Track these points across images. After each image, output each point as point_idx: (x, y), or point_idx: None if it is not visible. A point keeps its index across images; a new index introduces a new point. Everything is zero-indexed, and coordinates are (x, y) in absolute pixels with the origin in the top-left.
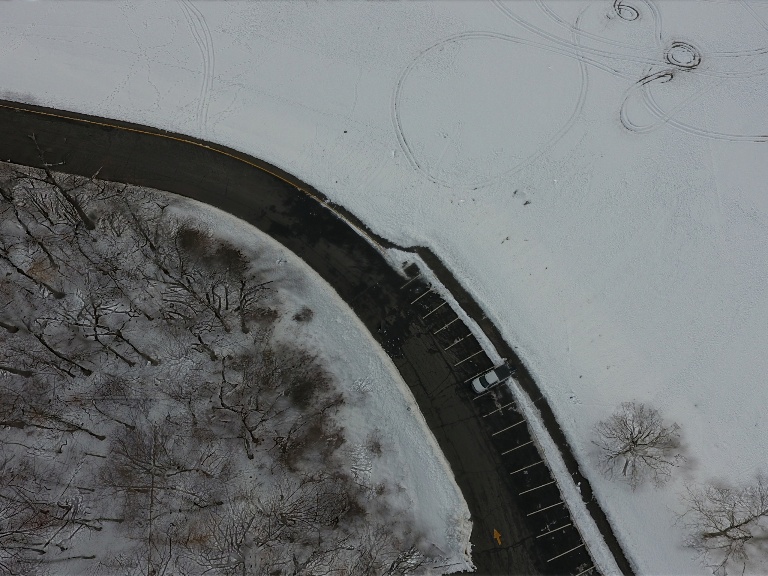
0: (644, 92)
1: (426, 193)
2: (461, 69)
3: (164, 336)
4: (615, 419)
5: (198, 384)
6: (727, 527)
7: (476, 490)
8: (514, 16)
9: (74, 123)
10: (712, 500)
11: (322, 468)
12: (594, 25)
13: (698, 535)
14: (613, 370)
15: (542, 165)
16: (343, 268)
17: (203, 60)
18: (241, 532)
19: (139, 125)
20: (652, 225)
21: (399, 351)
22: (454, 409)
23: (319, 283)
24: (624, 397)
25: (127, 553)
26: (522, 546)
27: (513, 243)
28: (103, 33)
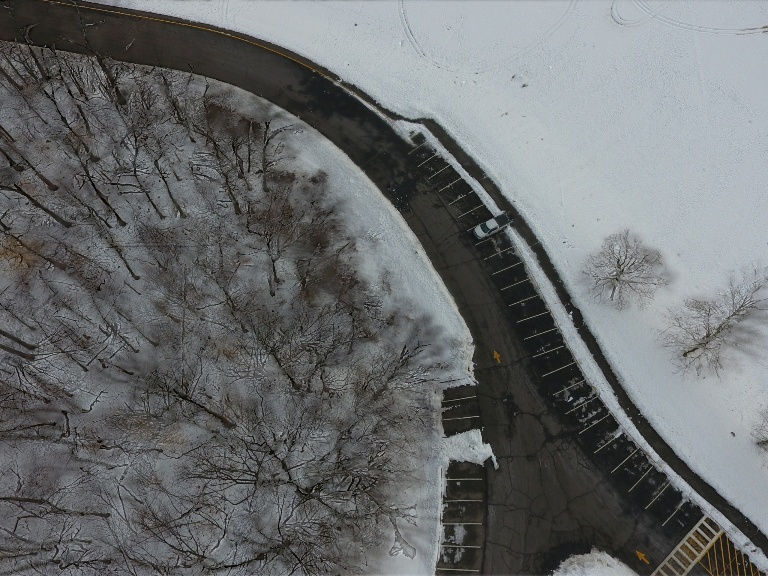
0: None
1: (431, 75)
2: None
3: (192, 193)
4: (604, 252)
5: (224, 234)
6: (703, 336)
7: (478, 319)
8: None
9: (105, 14)
10: (690, 308)
11: None
12: None
13: (678, 347)
14: (603, 222)
15: (538, 54)
16: (355, 137)
17: None
18: (265, 354)
19: (165, 16)
20: (640, 105)
21: (407, 206)
22: (458, 253)
23: (333, 150)
24: None
25: (163, 369)
26: (519, 364)
27: (511, 117)
28: None
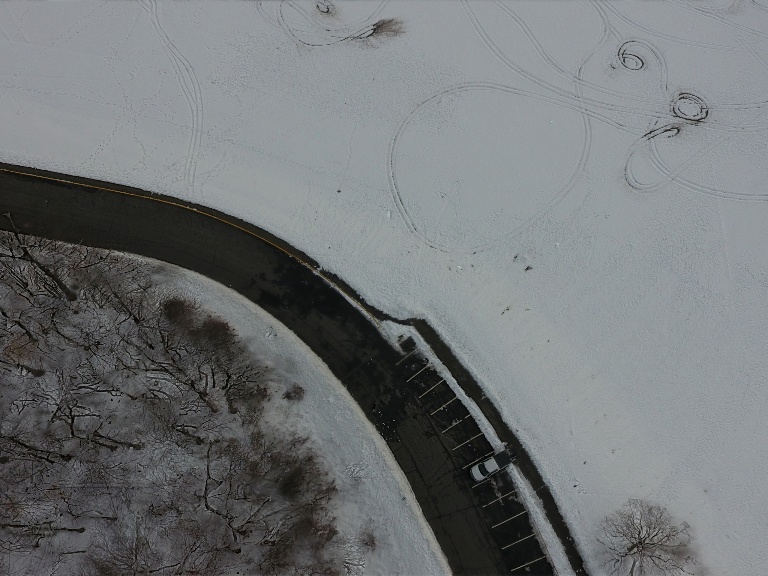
0: (650, 147)
1: (423, 259)
2: (459, 123)
3: (148, 418)
4: (621, 516)
5: (183, 470)
6: None
7: None
8: (514, 66)
9: (56, 184)
10: None
11: (313, 563)
12: (597, 75)
13: None
14: (619, 454)
15: (544, 227)
16: (336, 342)
17: (191, 114)
18: None
19: (124, 186)
20: (659, 292)
21: (394, 434)
22: (452, 498)
23: (311, 359)
24: (630, 484)
25: None
26: None
27: (514, 314)
28: (88, 85)
